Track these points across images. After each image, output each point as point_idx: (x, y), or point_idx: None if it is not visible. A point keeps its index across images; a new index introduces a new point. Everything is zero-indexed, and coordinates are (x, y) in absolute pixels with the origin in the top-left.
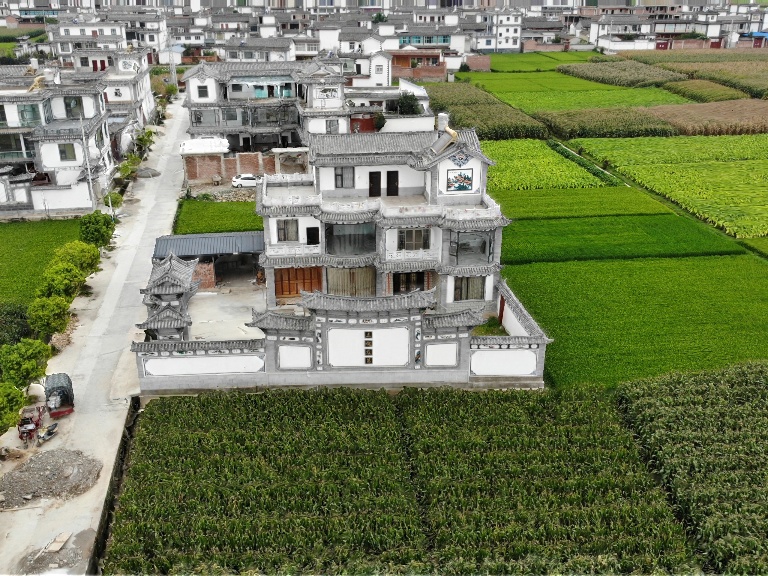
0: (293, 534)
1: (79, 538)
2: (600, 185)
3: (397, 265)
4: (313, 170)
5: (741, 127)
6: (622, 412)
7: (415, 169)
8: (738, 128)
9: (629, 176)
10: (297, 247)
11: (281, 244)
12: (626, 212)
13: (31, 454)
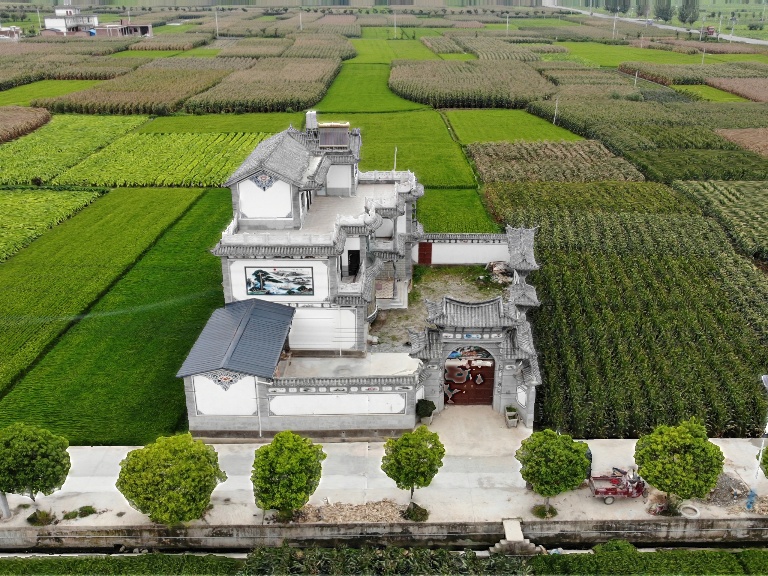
0: (742, 343)
1: (763, 446)
2: (97, 196)
3: (400, 249)
4: (258, 207)
5: (20, 127)
6: (553, 256)
7: (354, 163)
8: (19, 129)
9: (82, 184)
10: (361, 272)
11: (338, 282)
12: (190, 200)
13: (656, 490)
